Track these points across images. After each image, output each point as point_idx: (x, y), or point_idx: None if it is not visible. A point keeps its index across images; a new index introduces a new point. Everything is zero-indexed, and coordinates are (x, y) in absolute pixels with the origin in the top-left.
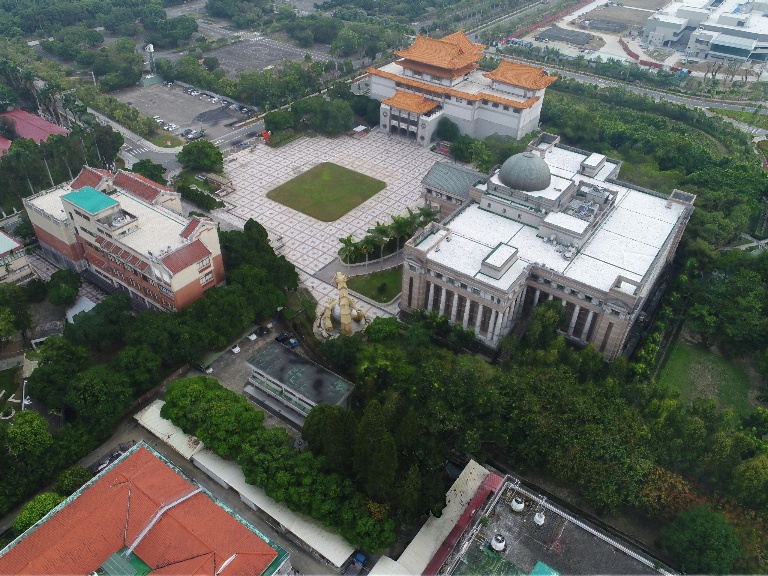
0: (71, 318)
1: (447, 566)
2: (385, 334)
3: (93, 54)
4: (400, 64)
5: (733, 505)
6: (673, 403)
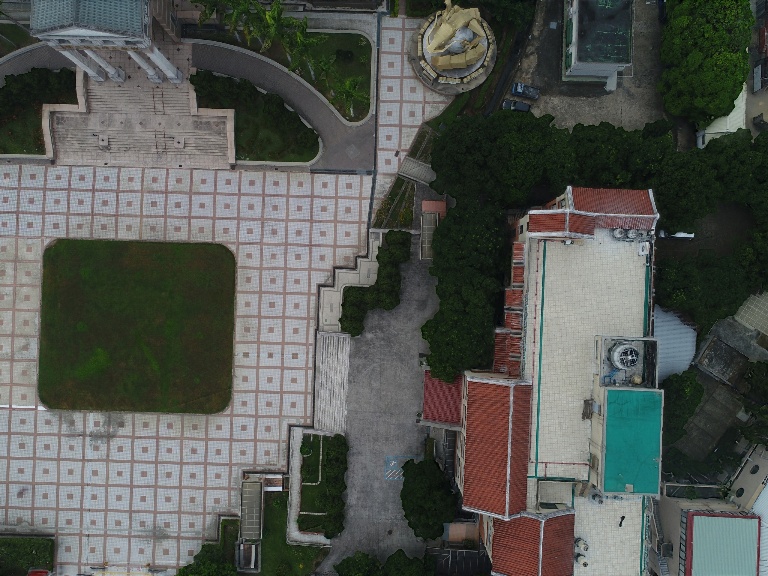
0: (689, 356)
1: None
2: None
3: None
4: None
5: None
6: None
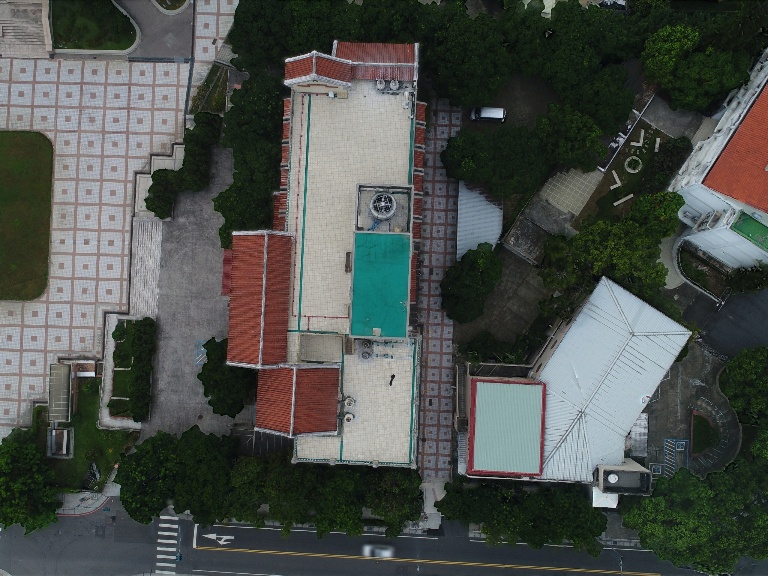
0: (495, 235)
1: None
2: None
3: None
4: None
5: None
6: None
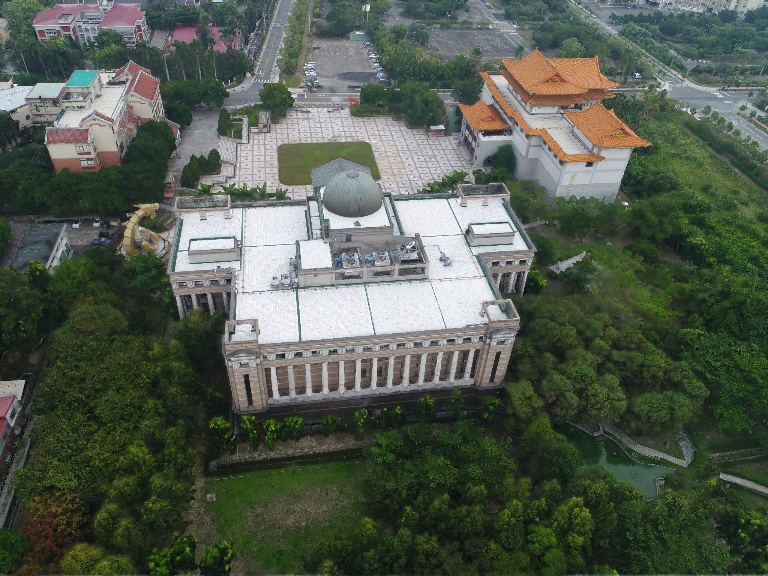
0: None
1: None
2: (131, 267)
3: (344, 5)
4: (504, 74)
5: (60, 575)
6: (137, 453)
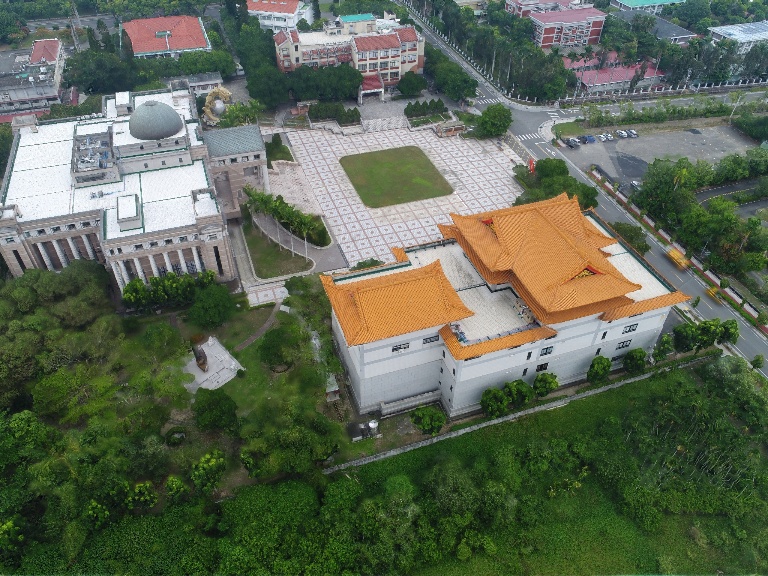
0: None
1: (70, 88)
2: None
3: None
4: None
5: None
6: None
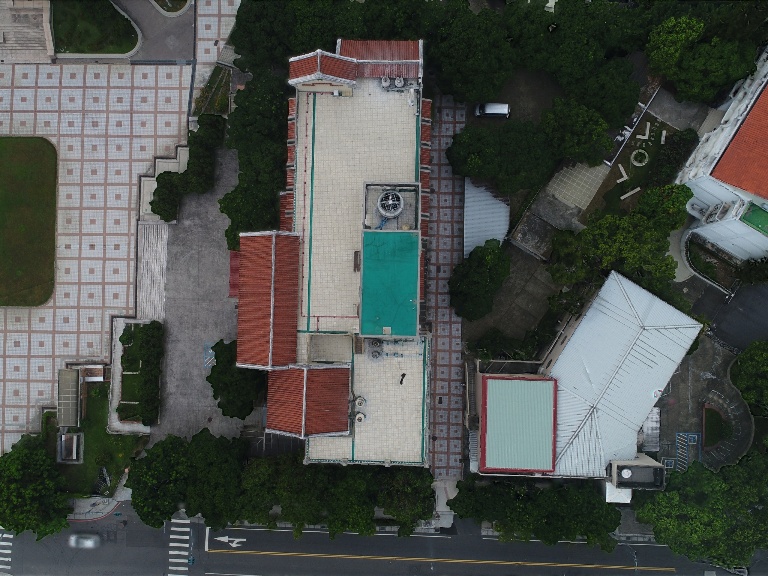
0: (502, 232)
1: None
2: None
3: None
4: None
5: None
6: None
